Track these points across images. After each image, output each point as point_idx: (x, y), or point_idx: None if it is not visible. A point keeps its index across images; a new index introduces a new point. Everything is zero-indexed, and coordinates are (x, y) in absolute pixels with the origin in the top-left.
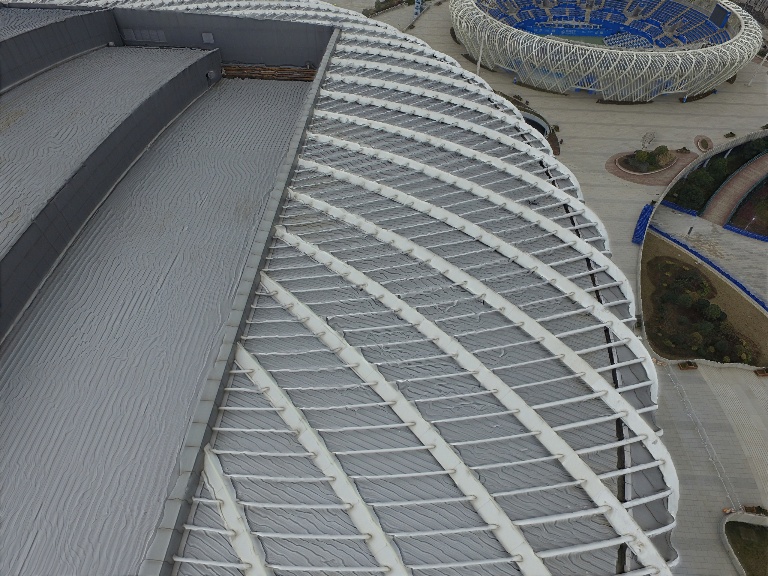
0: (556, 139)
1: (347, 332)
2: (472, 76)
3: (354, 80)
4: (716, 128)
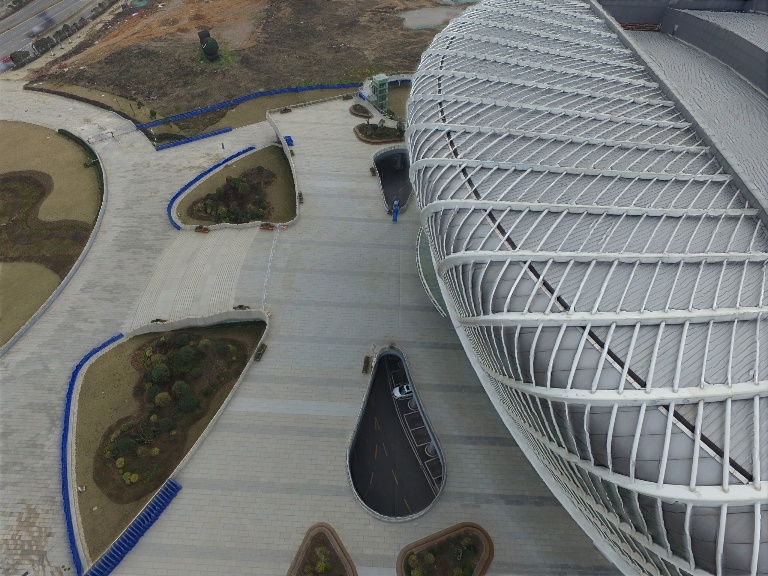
0: None
1: (574, 43)
2: (549, 315)
3: (712, 209)
4: None
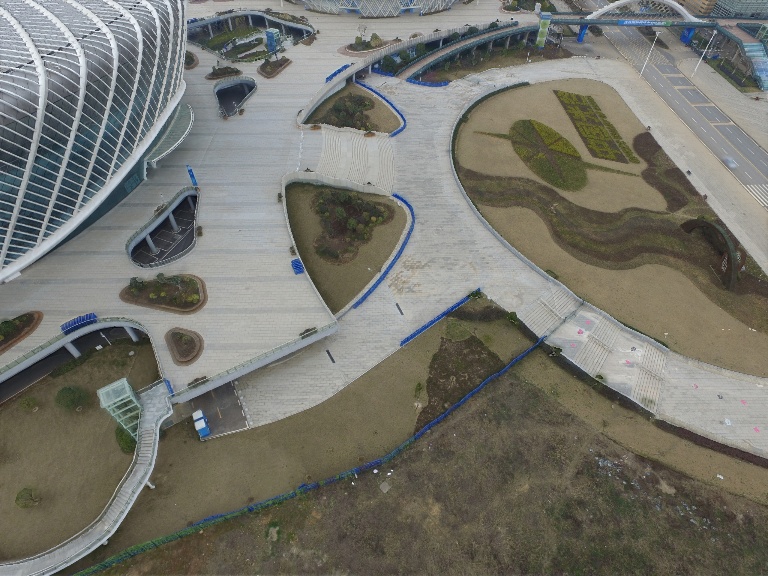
0: (314, 38)
1: None
2: None
3: None
4: (432, 28)
